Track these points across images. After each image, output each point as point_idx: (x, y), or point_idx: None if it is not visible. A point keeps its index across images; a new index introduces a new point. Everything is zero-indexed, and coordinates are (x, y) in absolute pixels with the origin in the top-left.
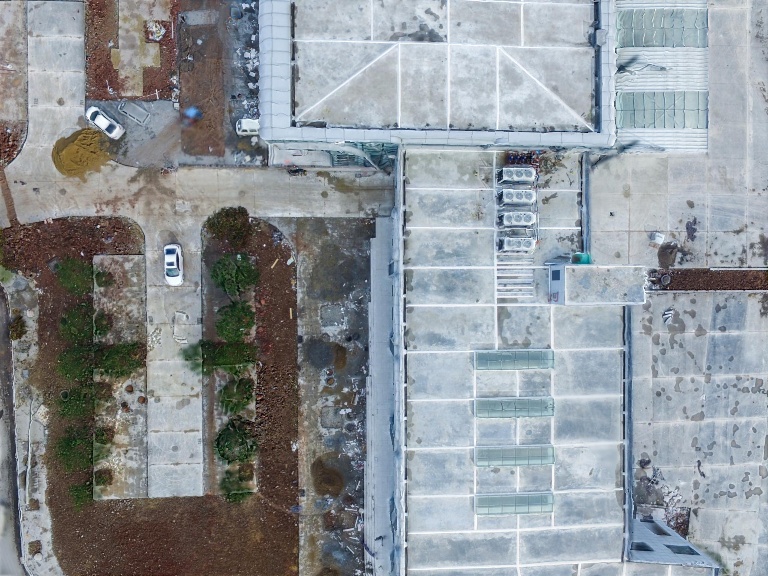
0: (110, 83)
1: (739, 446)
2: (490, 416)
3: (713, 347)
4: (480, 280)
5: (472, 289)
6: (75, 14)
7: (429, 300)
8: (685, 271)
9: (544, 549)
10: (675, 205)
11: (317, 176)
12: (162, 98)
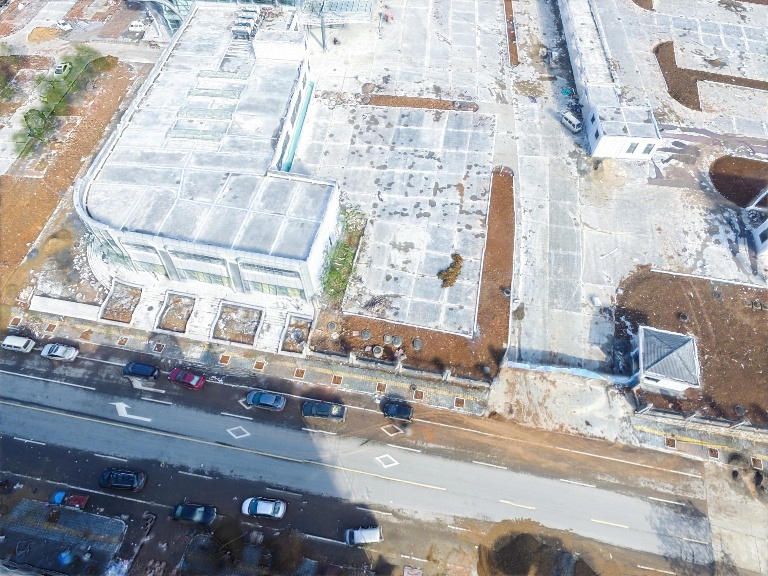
0: None
1: (413, 186)
2: (197, 95)
3: (398, 134)
4: (218, 48)
5: (212, 51)
6: None
7: (185, 53)
8: (380, 96)
9: (207, 162)
10: (377, 69)
11: None
12: None
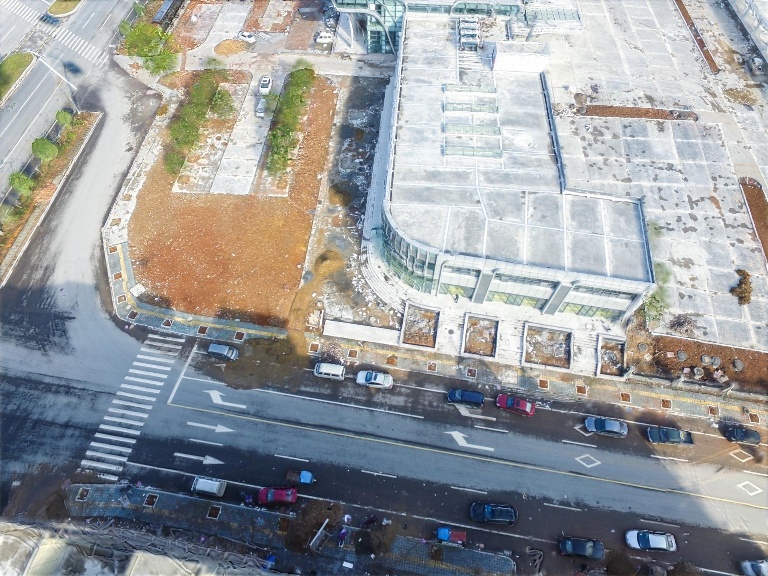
0: (254, 27)
1: (666, 200)
2: (454, 110)
3: (627, 145)
4: (448, 61)
5: (443, 64)
6: (246, 8)
7: (417, 67)
8: (595, 107)
9: (497, 180)
10: (581, 79)
11: (358, 62)
12: (279, 32)
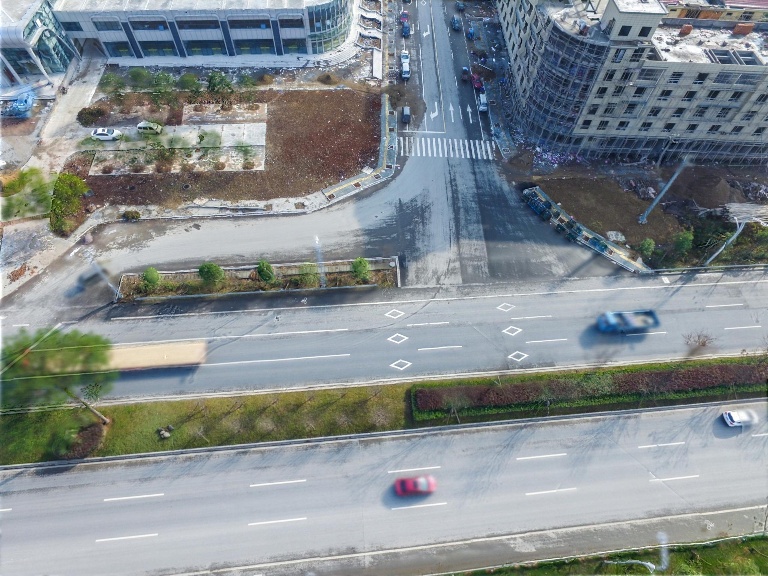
0: None
1: None
2: None
3: None
4: None
5: None
6: None
7: (143, 6)
8: None
9: None
10: None
11: (71, 85)
12: None
